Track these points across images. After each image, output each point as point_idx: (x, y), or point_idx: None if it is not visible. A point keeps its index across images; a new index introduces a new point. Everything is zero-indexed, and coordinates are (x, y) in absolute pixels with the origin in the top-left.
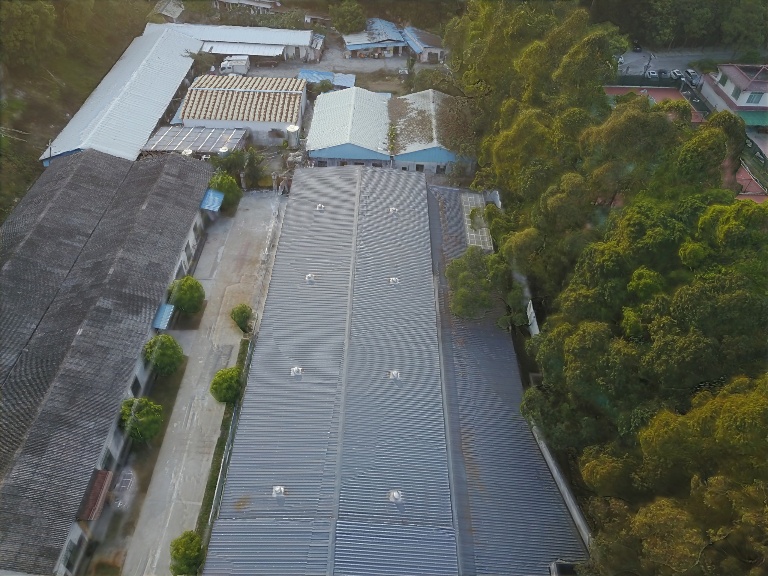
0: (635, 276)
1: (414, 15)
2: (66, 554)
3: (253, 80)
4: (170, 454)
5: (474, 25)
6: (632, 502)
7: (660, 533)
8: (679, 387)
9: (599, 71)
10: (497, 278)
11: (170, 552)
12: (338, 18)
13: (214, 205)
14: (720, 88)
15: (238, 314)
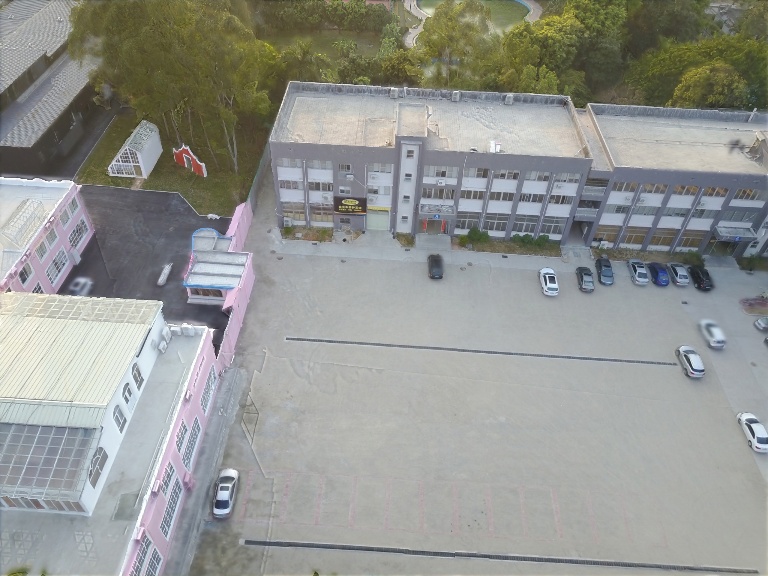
0: None
1: None
2: None
3: None
4: None
5: None
6: None
7: None
8: None
9: None
10: None
11: None
12: None
13: None
14: None
15: None
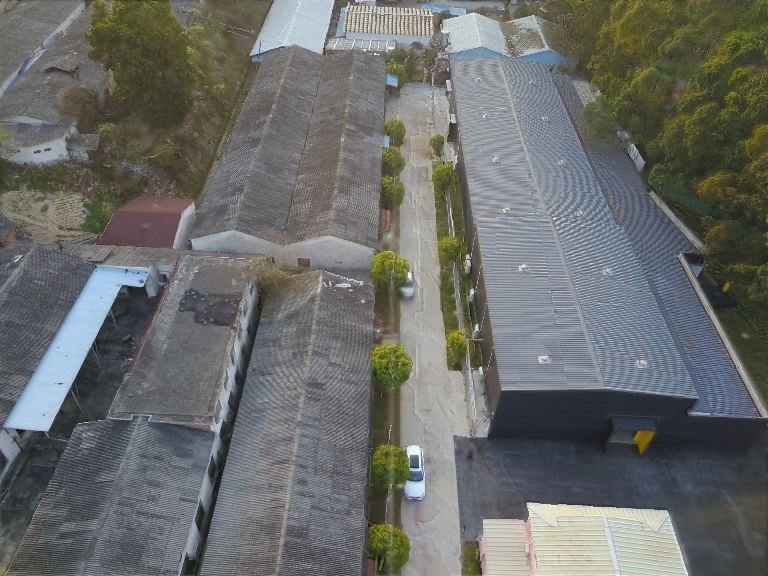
0: (734, 73)
1: None
2: None
3: (390, 9)
4: (407, 219)
5: None
6: None
7: (767, 166)
8: (767, 123)
9: None
10: (622, 111)
11: (440, 246)
12: None
13: (393, 83)
14: None
15: (437, 140)
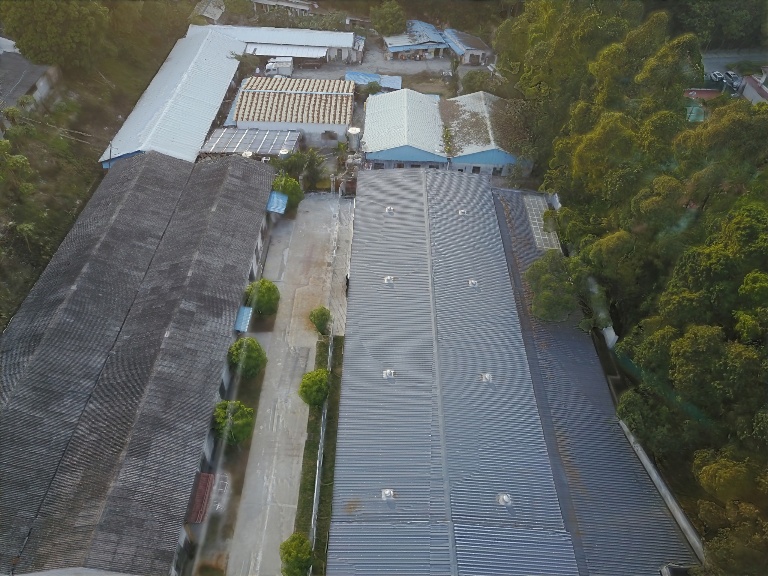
0: (749, 280)
1: (453, 17)
2: (175, 557)
3: (302, 82)
4: (260, 457)
5: (535, 27)
6: (760, 506)
7: None
8: None
9: (689, 74)
10: (580, 281)
11: (280, 555)
12: (379, 20)
13: (279, 207)
14: (764, 90)
15: (318, 316)
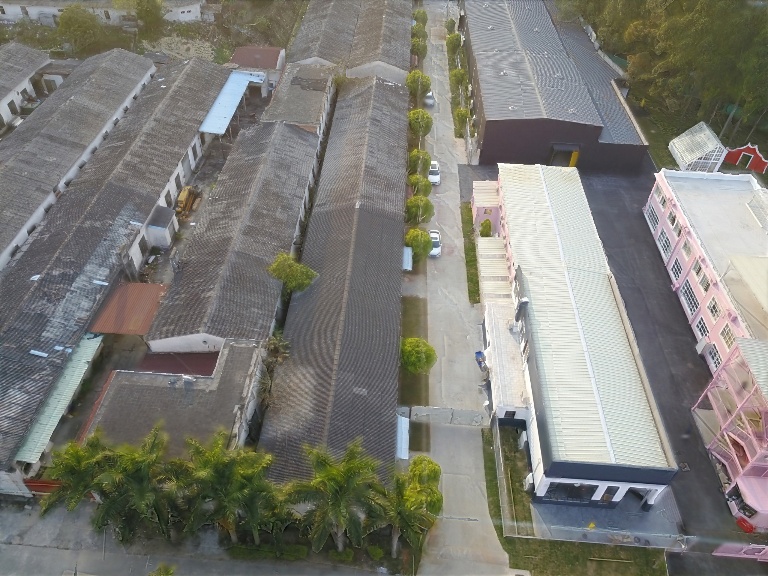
0: None
1: None
2: None
3: None
4: (429, 70)
5: None
6: None
7: (655, 0)
8: None
9: None
10: (582, 0)
11: (451, 74)
12: None
13: None
14: None
15: (450, 22)
